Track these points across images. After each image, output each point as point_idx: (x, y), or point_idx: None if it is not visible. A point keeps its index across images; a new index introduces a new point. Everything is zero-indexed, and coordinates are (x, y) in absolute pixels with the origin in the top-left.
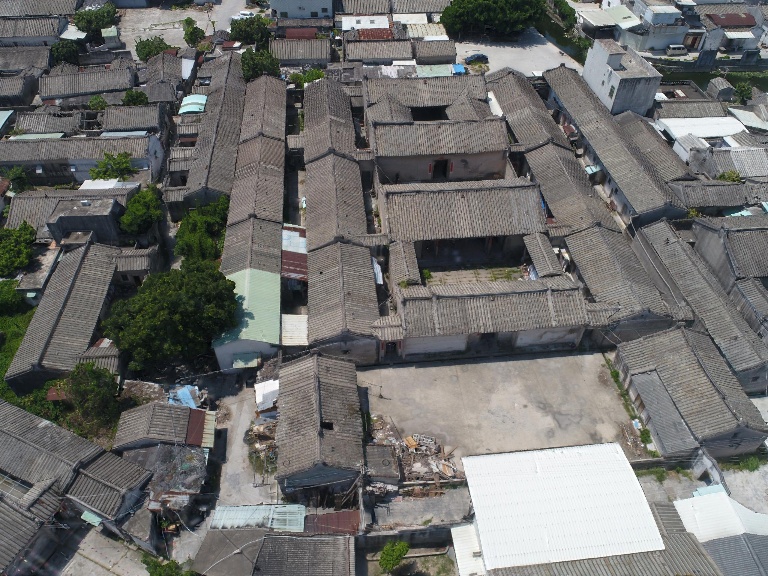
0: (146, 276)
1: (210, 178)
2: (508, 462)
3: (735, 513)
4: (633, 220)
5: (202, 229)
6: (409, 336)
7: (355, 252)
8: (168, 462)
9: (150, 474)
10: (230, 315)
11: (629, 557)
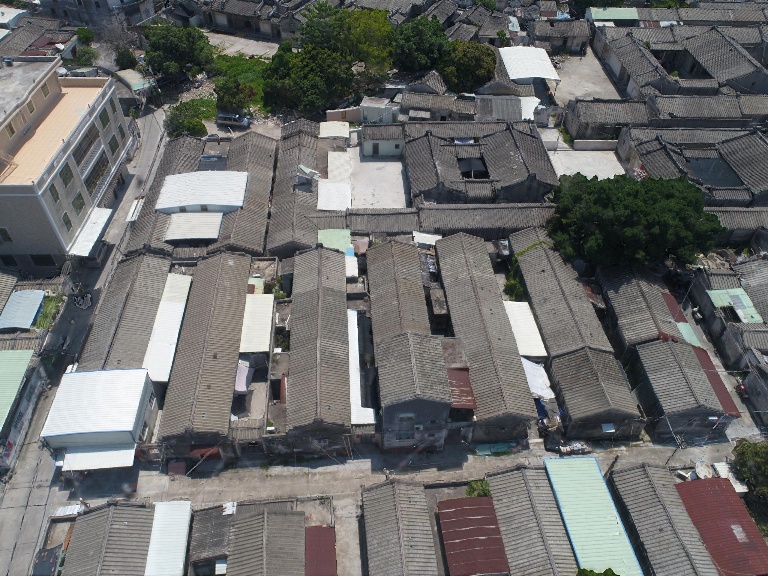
0: (626, 1)
1: (709, 3)
2: (544, 56)
3: (530, 101)
4: (765, 124)
5: (665, 6)
6: (610, 43)
7: (666, 35)
8: (532, 10)
9: (526, 6)
10: (601, 1)
11: (506, 73)
